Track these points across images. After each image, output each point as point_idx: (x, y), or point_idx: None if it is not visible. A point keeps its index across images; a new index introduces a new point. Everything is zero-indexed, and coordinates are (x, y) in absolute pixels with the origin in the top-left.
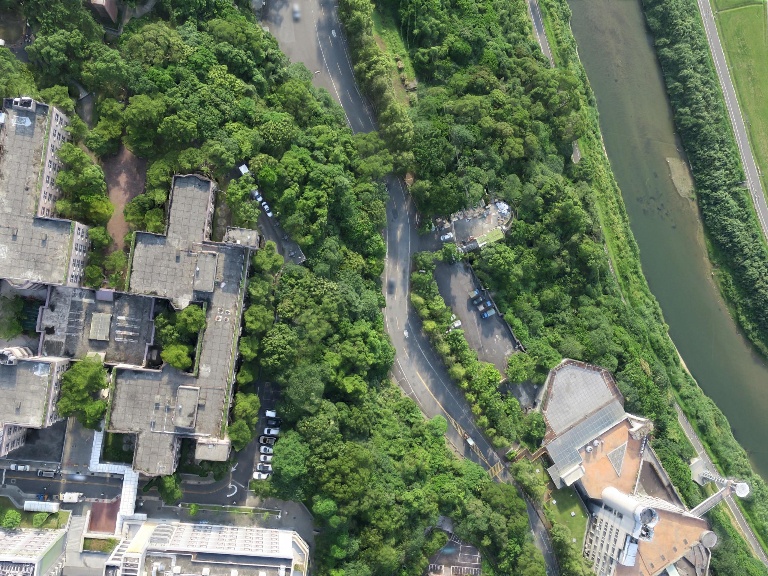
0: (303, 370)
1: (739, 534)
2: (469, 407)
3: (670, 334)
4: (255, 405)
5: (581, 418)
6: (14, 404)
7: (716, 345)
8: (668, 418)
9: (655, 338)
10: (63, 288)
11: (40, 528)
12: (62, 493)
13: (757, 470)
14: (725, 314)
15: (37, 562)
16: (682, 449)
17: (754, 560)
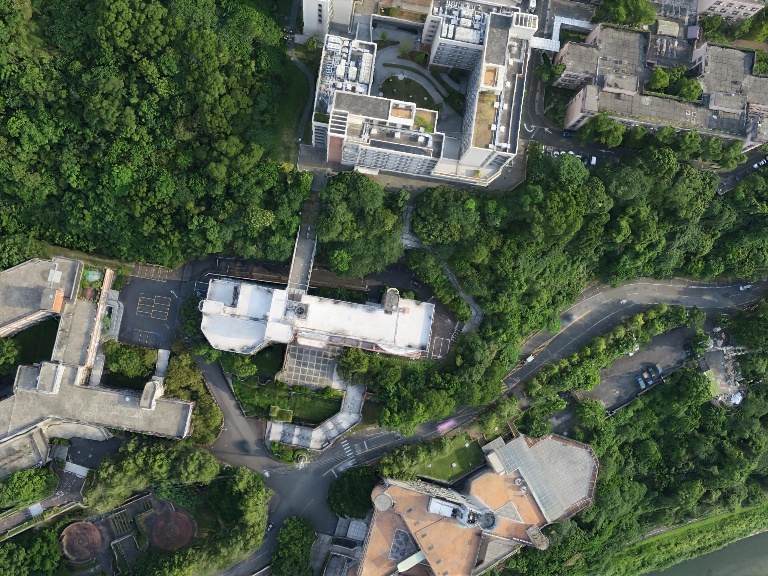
0: None
1: None
2: (558, 360)
3: None
4: (615, 141)
5: None
6: None
7: None
8: None
9: None
10: (696, 3)
11: None
12: None
13: None
14: None
15: None
16: None
17: None
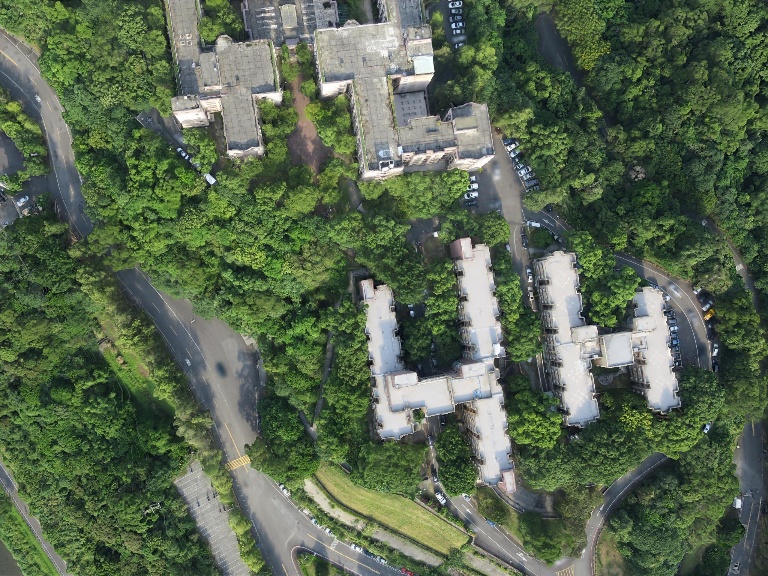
0: (103, 8)
1: None
2: None
3: None
4: None
5: None
6: None
7: None
8: None
9: None
10: None
11: None
12: None
13: None
14: None
15: None
16: None
17: None
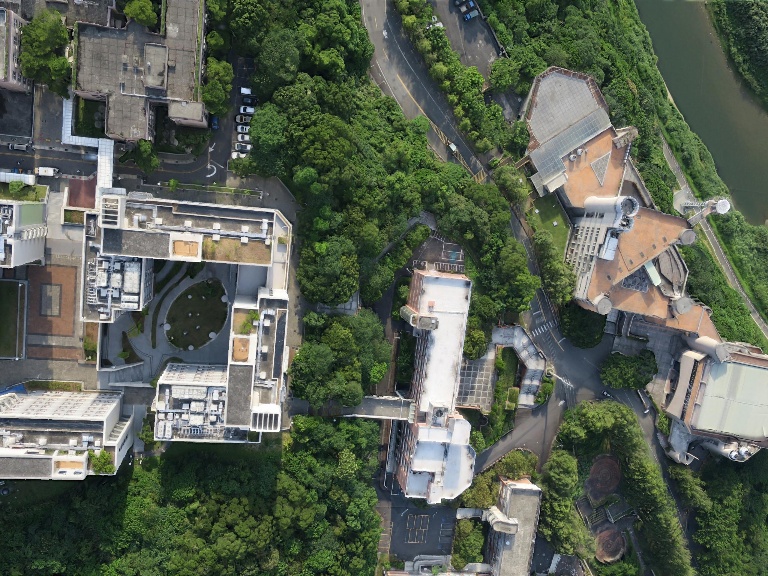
0: (276, 33)
1: (716, 265)
2: (451, 113)
3: (659, 68)
4: (228, 71)
5: (565, 128)
6: None
7: (705, 80)
8: (653, 146)
9: (643, 67)
10: None
11: (18, 199)
12: (37, 167)
13: (738, 208)
14: (716, 47)
15: (15, 204)
16: (665, 176)
17: (729, 288)
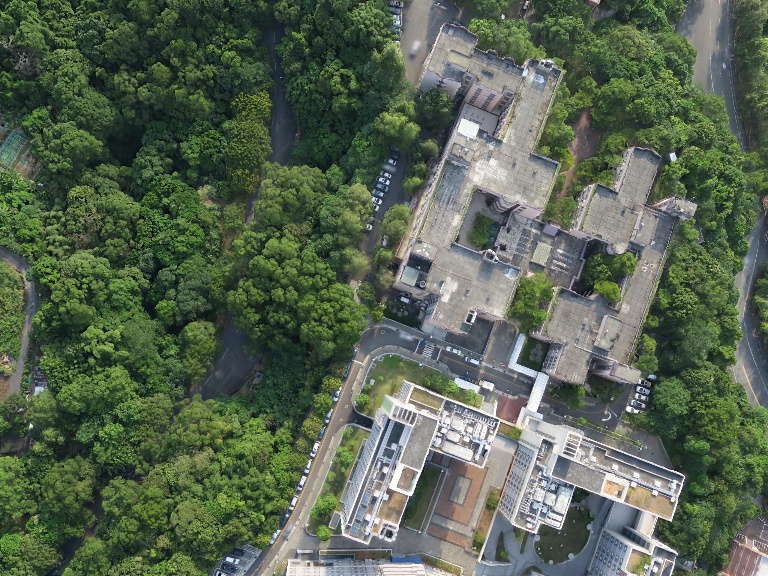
0: (700, 329)
1: None
2: None
3: None
4: None
5: None
6: (486, 295)
7: None
8: None
9: None
10: (519, 216)
11: (463, 402)
12: (481, 380)
13: None
14: None
15: None
16: None
17: None
